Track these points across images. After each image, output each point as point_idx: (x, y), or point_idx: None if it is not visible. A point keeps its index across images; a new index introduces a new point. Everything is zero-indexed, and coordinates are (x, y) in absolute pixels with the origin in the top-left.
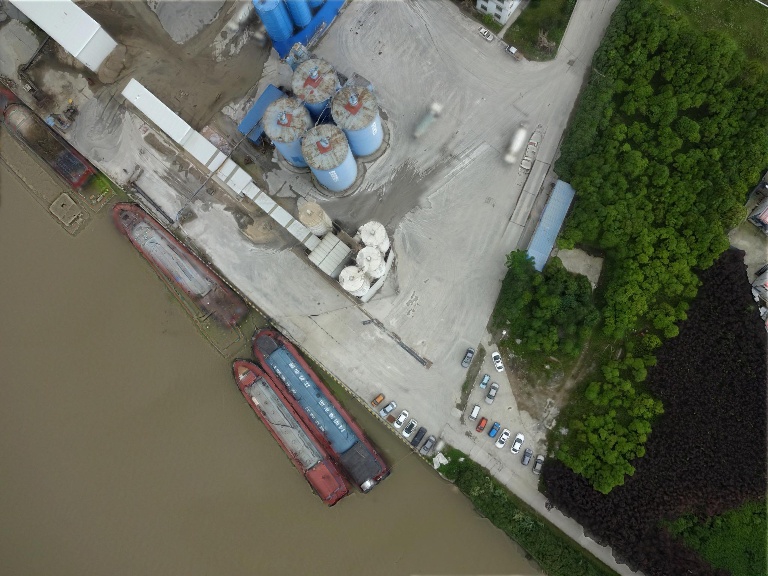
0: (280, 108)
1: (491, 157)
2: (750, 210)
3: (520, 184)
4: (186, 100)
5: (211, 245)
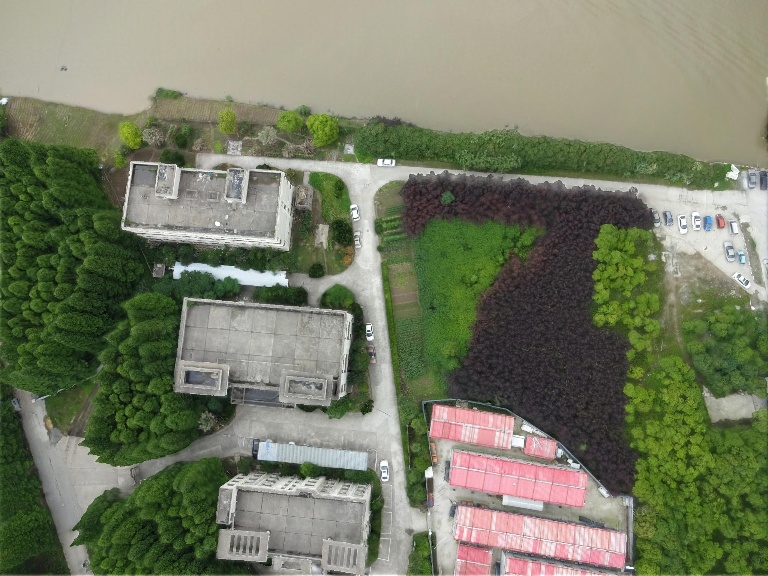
0: None
1: None
2: None
3: None
4: None
5: None
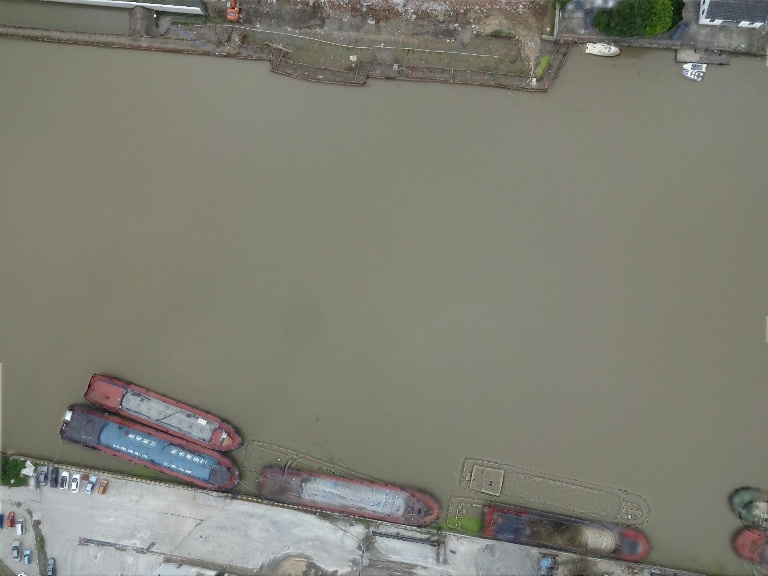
0: None
1: None
2: None
3: None
4: None
5: (328, 531)
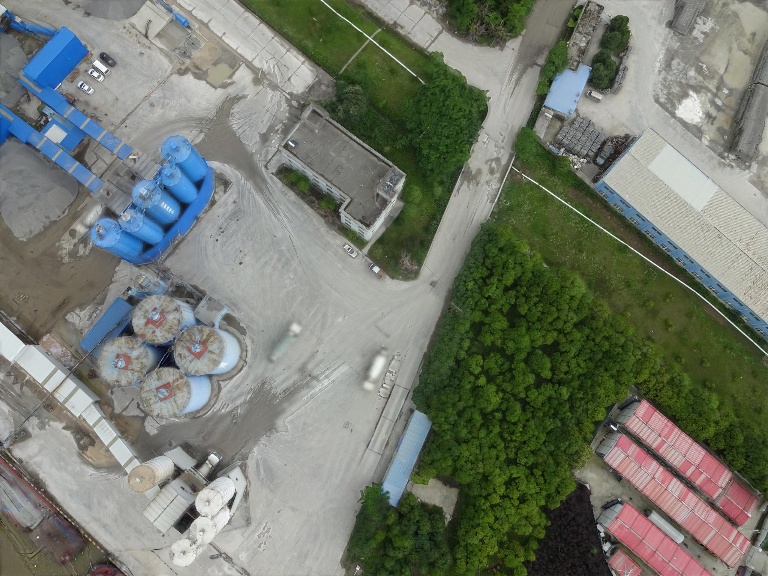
0: (118, 348)
1: (351, 379)
2: (598, 442)
3: (379, 409)
4: (26, 303)
5: (45, 469)
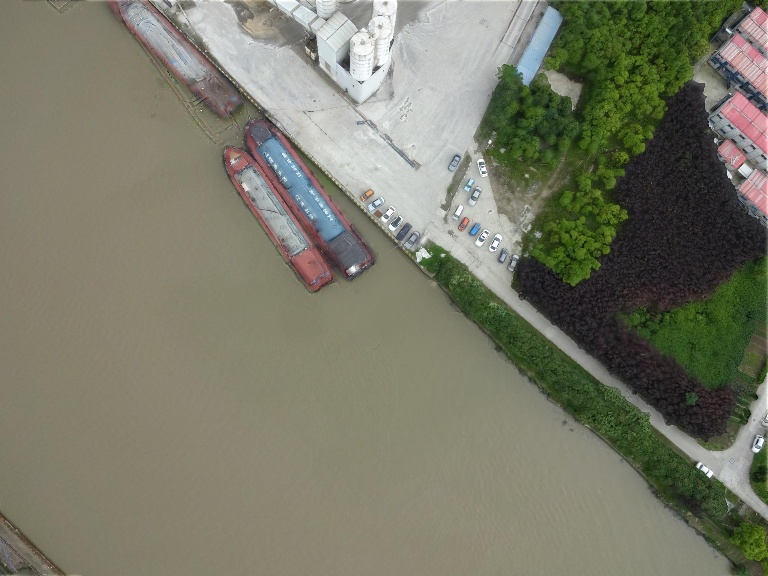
0: None
1: None
2: (710, 54)
3: (513, 10)
4: None
5: (209, 34)
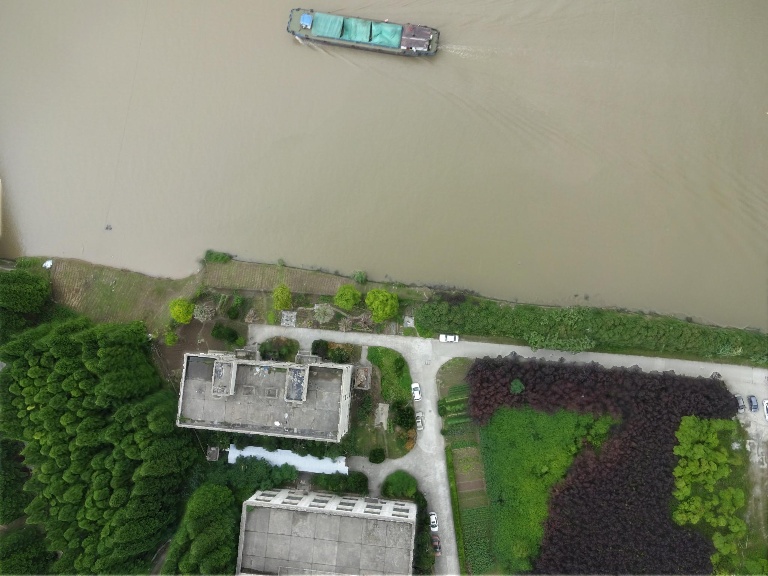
0: None
1: None
2: None
3: None
4: None
5: None
